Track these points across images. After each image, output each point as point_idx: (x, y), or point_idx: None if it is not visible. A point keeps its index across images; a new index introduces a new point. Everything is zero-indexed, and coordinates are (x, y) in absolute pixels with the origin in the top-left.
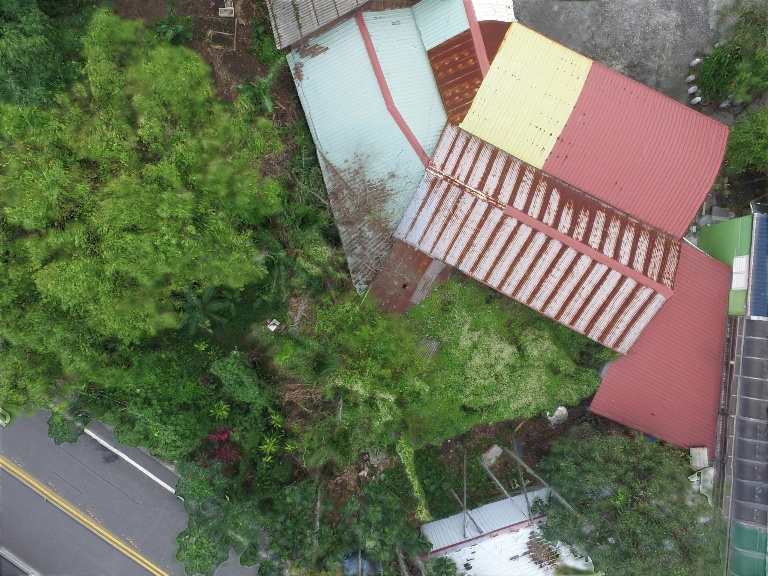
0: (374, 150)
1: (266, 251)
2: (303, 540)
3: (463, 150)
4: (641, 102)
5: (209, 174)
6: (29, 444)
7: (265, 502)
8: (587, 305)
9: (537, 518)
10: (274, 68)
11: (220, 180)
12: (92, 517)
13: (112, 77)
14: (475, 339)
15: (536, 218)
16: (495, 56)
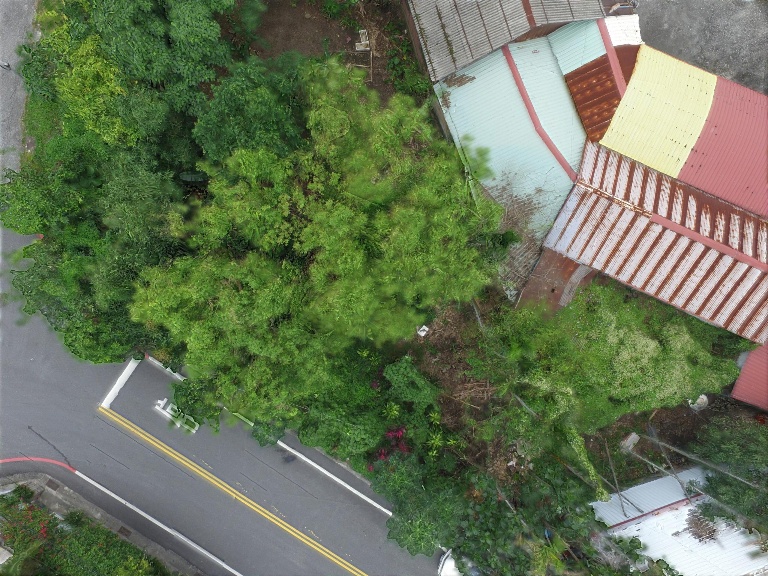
0: (522, 168)
1: (443, 265)
2: (495, 523)
3: (606, 164)
4: (766, 112)
5: None
6: (217, 448)
7: None
8: (727, 301)
9: (694, 497)
10: (409, 95)
11: None
12: (277, 512)
13: (343, 121)
14: (621, 336)
15: (679, 223)
16: (630, 77)
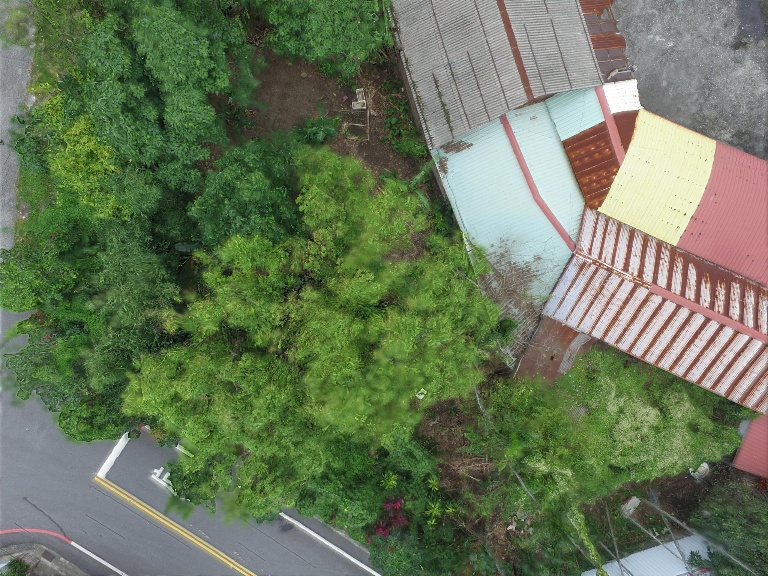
0: (520, 236)
1: (440, 340)
2: None
3: (605, 233)
4: (766, 179)
5: (353, 256)
6: (214, 517)
7: (430, 561)
8: (728, 370)
9: (695, 571)
10: (406, 155)
11: (364, 262)
12: None
13: (338, 213)
14: (621, 405)
15: (679, 294)
16: (629, 145)
